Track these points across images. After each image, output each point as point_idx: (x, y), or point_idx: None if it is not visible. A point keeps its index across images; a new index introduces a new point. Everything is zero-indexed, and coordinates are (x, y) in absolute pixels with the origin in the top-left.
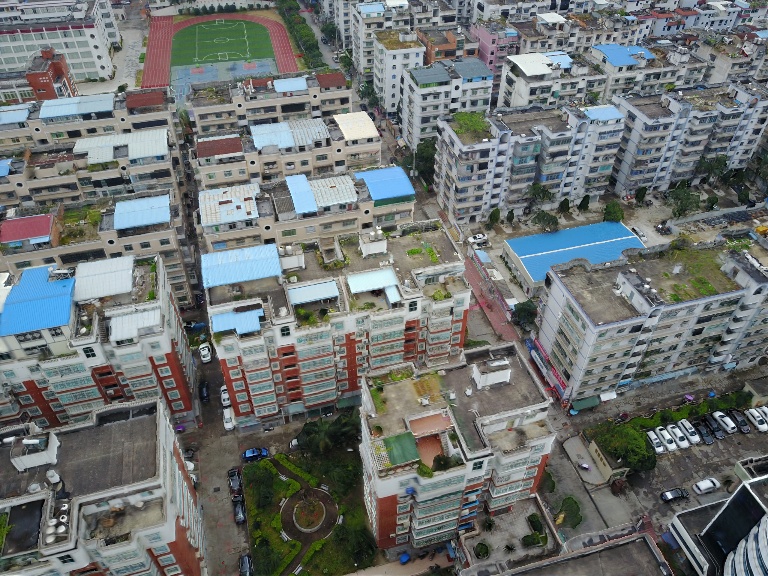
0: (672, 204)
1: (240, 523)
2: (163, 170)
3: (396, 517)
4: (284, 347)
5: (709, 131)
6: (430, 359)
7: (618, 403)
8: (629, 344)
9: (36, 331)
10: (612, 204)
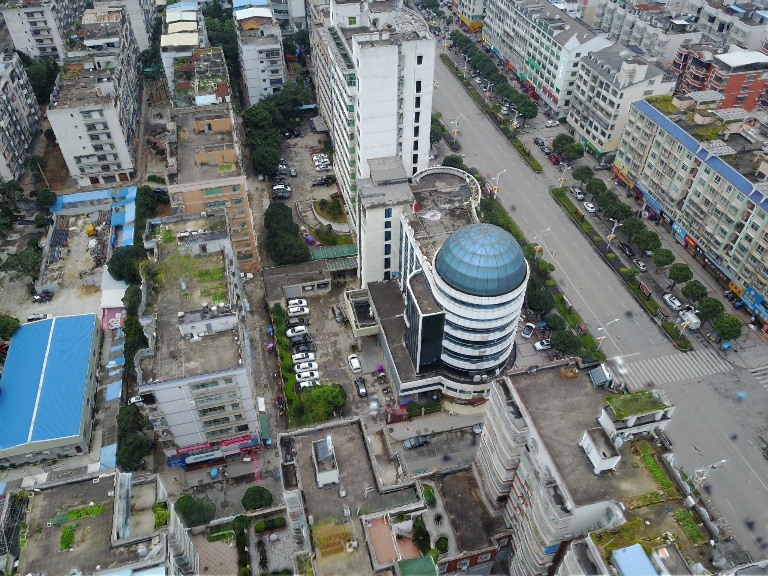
0: (18, 274)
1: None
2: None
3: None
4: None
5: None
6: (195, 573)
7: None
8: None
9: None
10: None
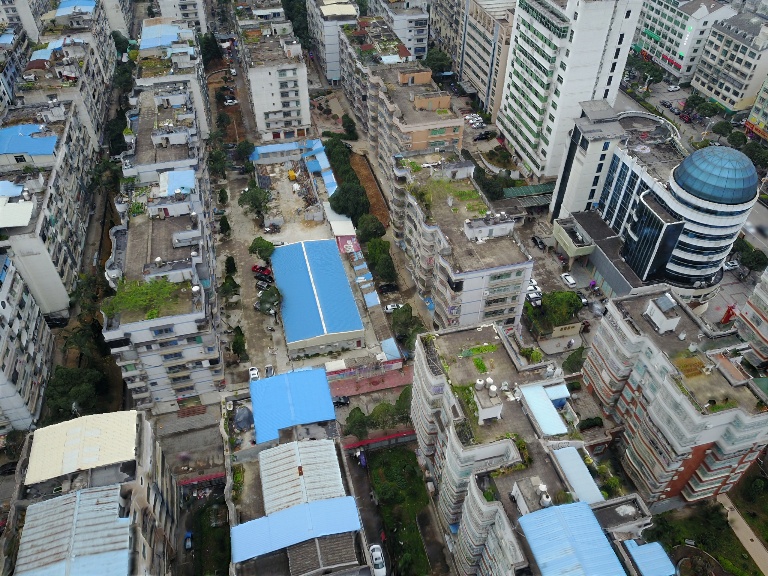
0: (252, 209)
1: None
2: None
3: None
4: None
5: None
6: None
7: None
8: None
9: None
10: (261, 241)
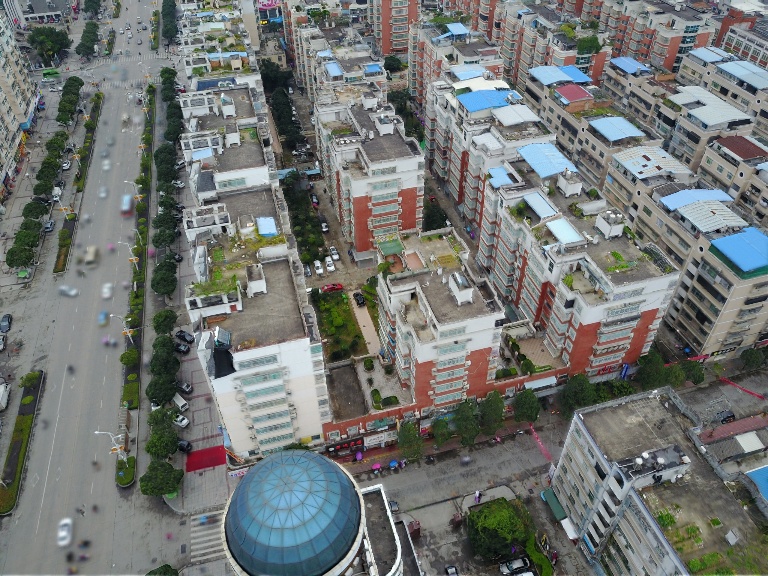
0: None
1: None
2: (696, 135)
3: None
4: None
5: None
6: None
7: (575, 557)
8: (593, 485)
9: None
10: None
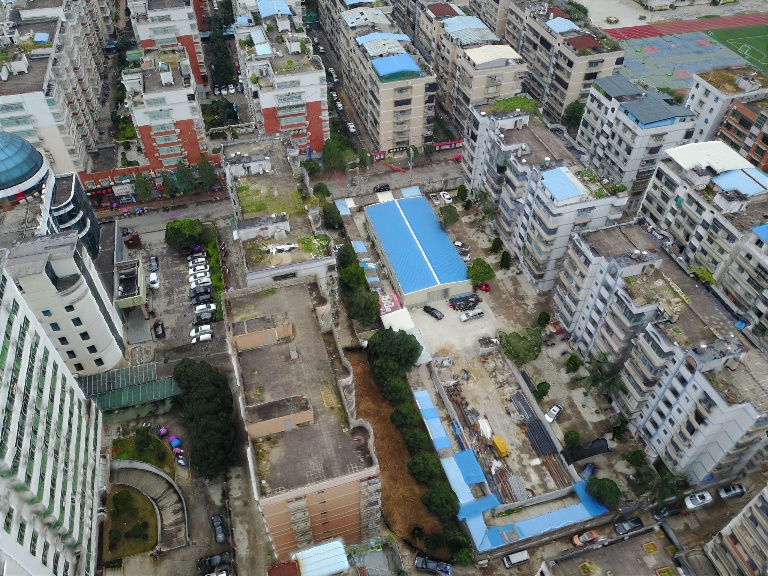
0: None
1: None
2: (423, 6)
3: None
4: None
5: None
6: None
7: None
8: None
9: None
10: (479, 259)
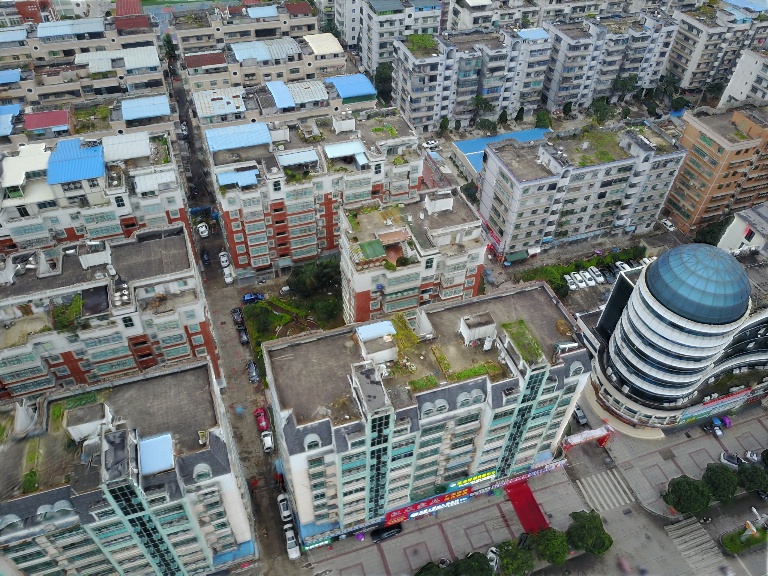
0: (593, 115)
1: (245, 343)
2: (156, 80)
3: (369, 314)
4: (275, 203)
5: (623, 52)
6: None
7: (542, 258)
8: (548, 201)
9: (78, 181)
10: (542, 113)
